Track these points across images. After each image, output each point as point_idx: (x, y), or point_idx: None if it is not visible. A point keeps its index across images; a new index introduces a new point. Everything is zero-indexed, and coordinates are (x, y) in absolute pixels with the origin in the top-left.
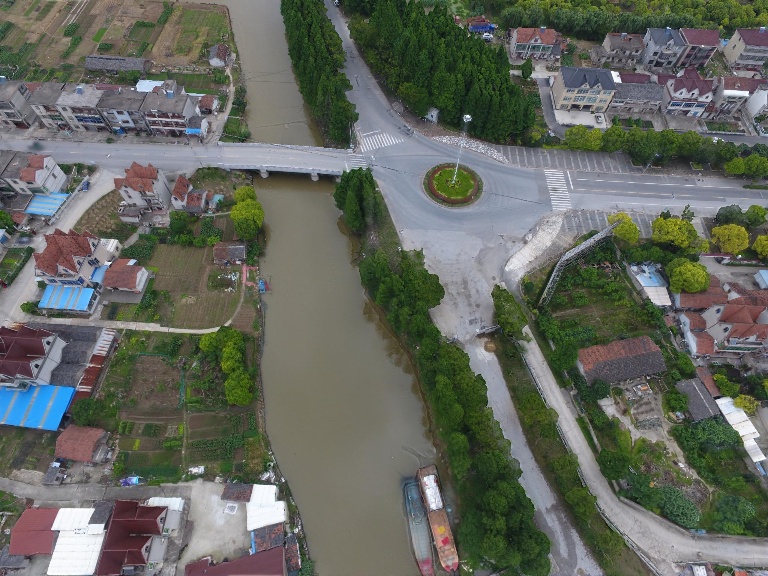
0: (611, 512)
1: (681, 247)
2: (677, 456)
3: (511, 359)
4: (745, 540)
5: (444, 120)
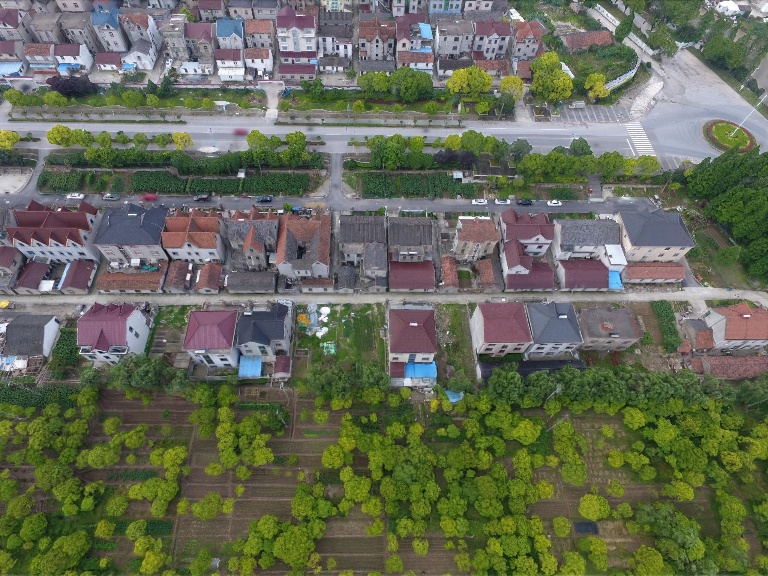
0: None
1: None
2: None
3: (645, 40)
4: None
5: None
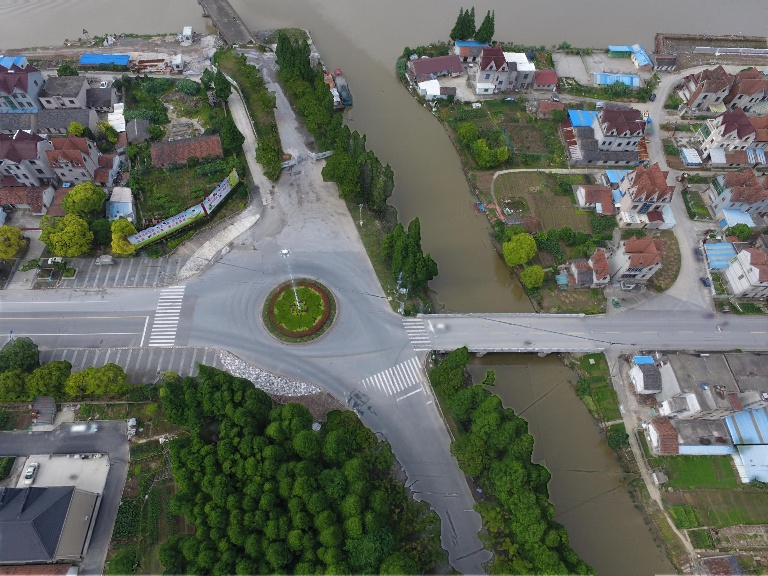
0: None
1: None
2: (172, 112)
3: None
4: None
5: None
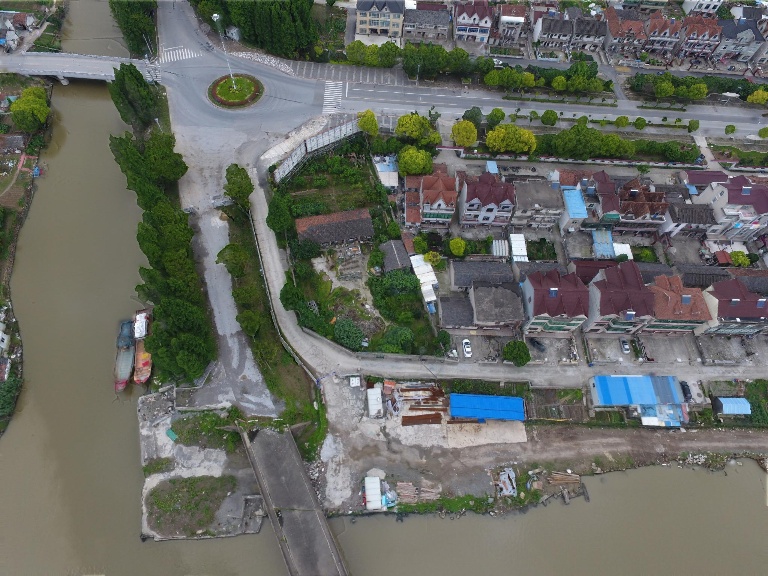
0: (292, 339)
1: (416, 139)
2: (367, 300)
3: (239, 225)
4: (402, 360)
5: (244, 38)
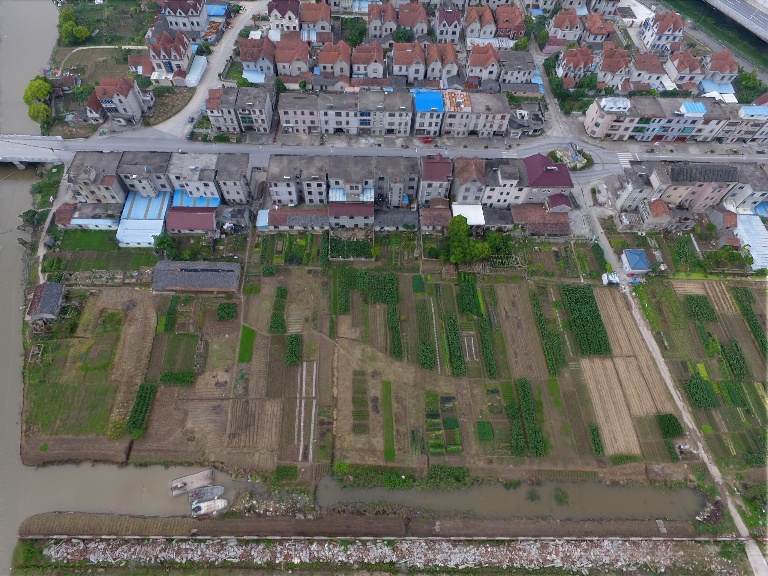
0: None
1: None
2: None
3: None
4: None
5: None
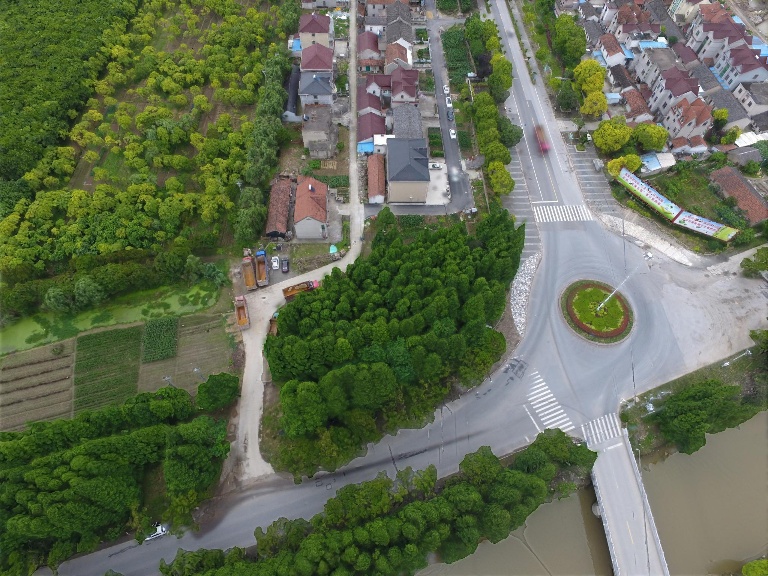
0: None
1: None
2: None
3: None
4: None
5: None
